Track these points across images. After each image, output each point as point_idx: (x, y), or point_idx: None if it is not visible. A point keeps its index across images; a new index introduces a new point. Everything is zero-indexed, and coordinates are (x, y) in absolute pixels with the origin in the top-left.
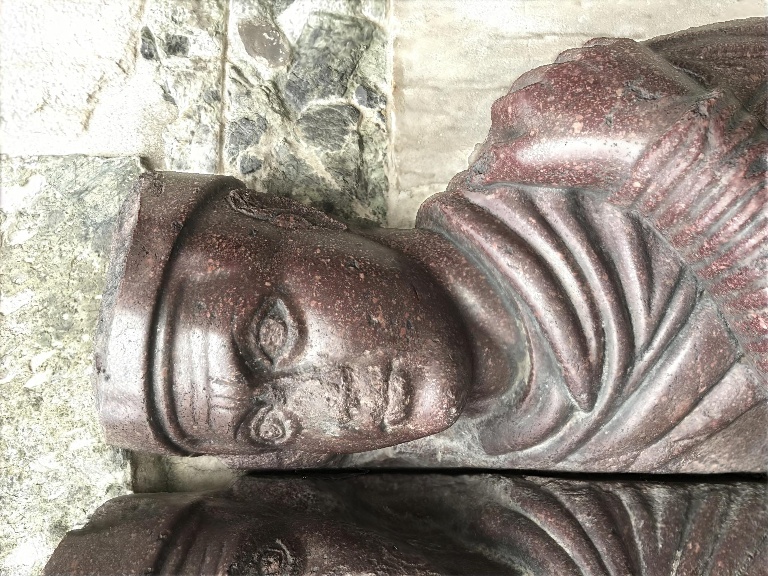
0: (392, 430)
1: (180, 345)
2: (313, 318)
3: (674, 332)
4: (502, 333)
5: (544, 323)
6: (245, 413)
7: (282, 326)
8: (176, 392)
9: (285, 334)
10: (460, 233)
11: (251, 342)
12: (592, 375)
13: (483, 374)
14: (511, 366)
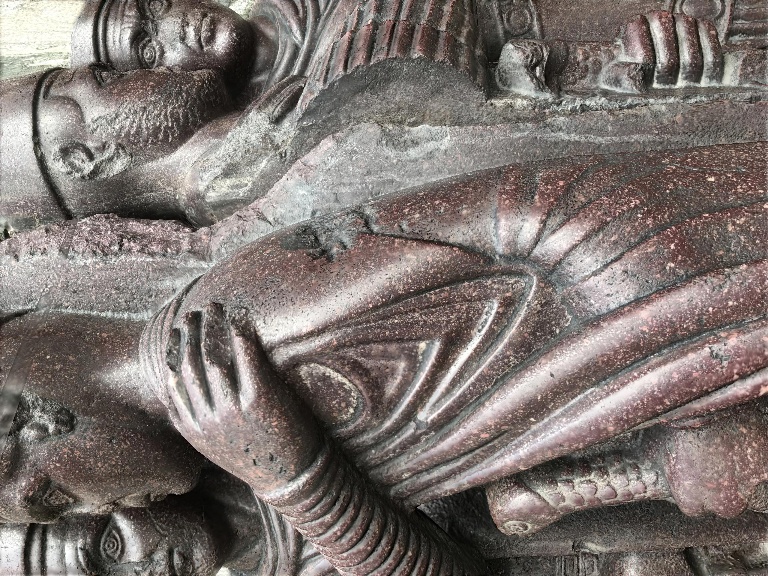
0: (206, 51)
1: (114, 6)
2: (175, 2)
3: (336, 1)
4: (269, 31)
5: (280, 7)
6: (137, 32)
7: (161, 3)
8: (108, 25)
9: (162, 6)
10: (257, 8)
11: (145, 5)
12: (301, 22)
13: (260, 49)
14: (274, 47)
